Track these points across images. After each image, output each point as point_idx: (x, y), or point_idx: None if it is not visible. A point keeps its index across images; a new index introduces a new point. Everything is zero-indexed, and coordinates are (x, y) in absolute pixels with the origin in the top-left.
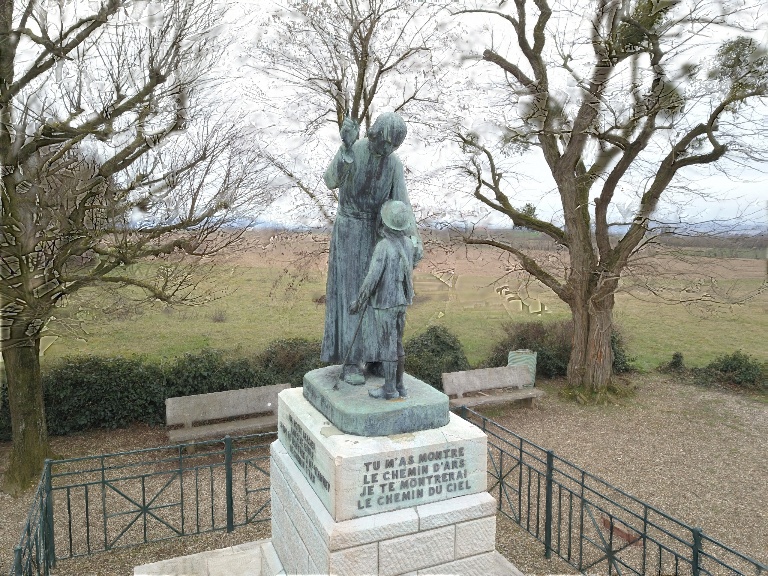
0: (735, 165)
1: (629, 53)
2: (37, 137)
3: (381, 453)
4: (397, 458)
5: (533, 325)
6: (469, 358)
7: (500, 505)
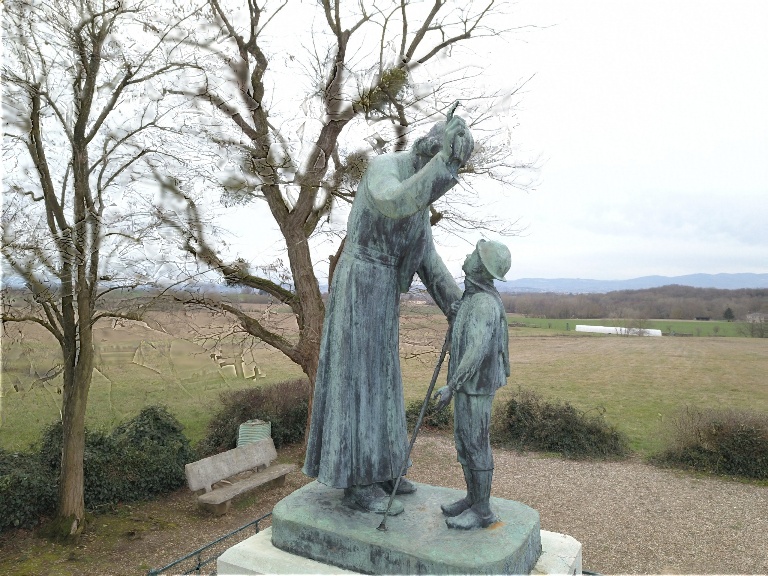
0: (443, 231)
1: (382, 118)
2: None
3: None
4: None
5: (251, 392)
6: None
7: None
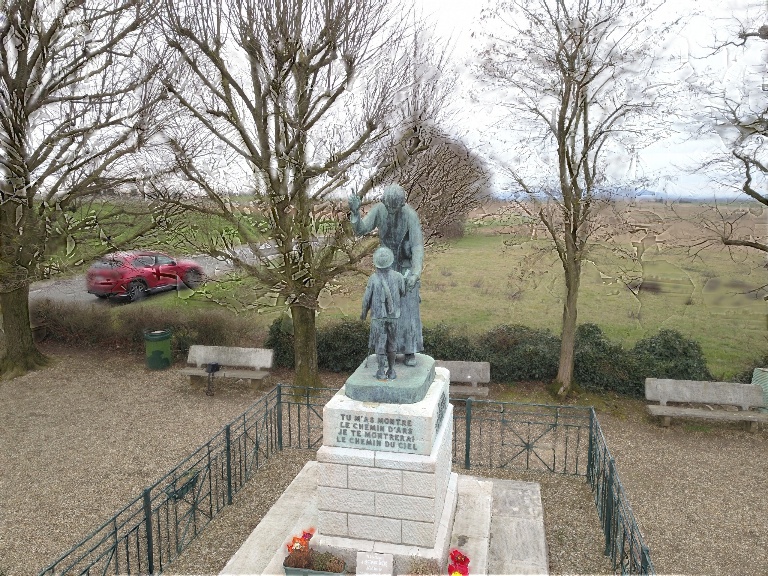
0: None
1: None
2: (296, 177)
3: (352, 411)
4: (362, 416)
5: None
6: (713, 368)
7: (597, 502)
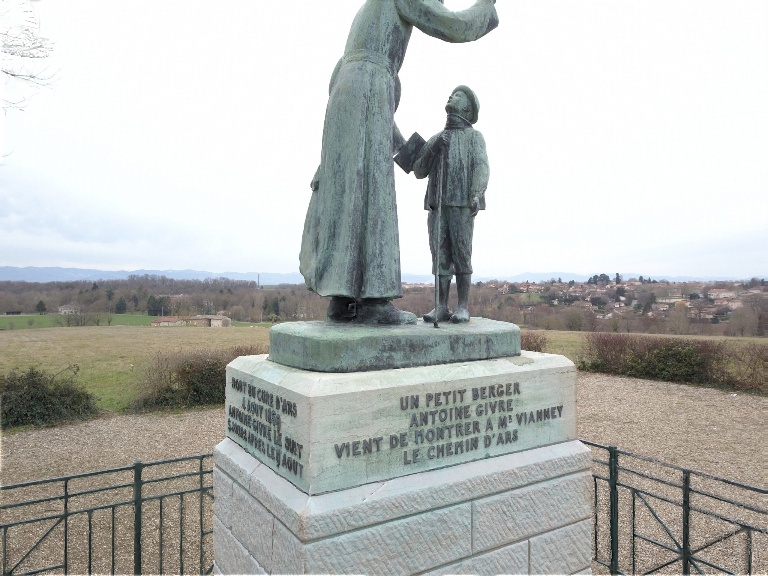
0: None
1: None
2: None
3: None
4: None
5: None
6: None
7: None
